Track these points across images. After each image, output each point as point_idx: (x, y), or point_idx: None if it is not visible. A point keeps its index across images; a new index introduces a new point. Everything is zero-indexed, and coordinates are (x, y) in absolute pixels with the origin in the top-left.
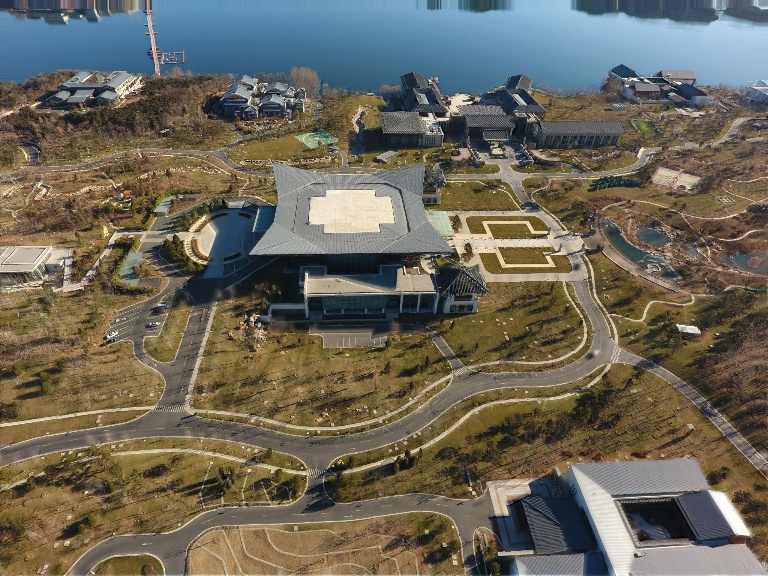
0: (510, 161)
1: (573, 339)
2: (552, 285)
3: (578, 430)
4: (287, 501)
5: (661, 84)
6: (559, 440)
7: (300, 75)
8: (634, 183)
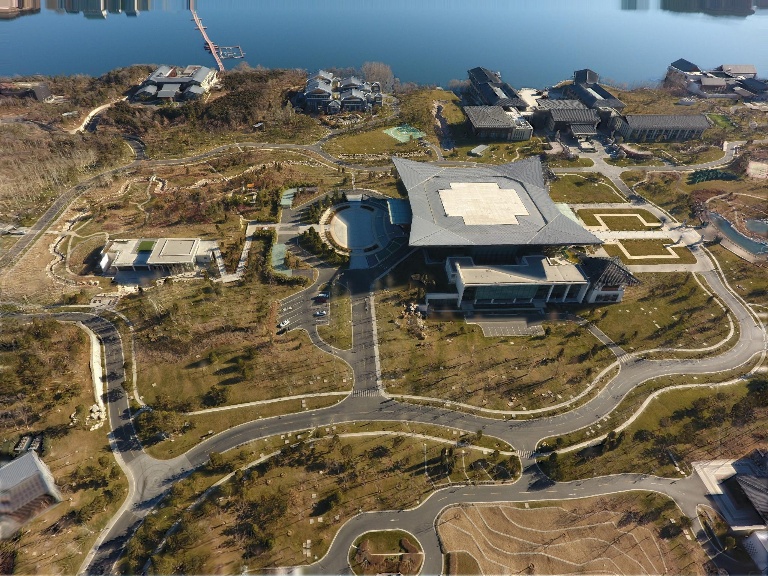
0: (601, 155)
1: (721, 327)
2: (688, 275)
3: (760, 414)
4: (510, 480)
5: (726, 78)
6: (745, 423)
7: (372, 70)
8: (731, 176)
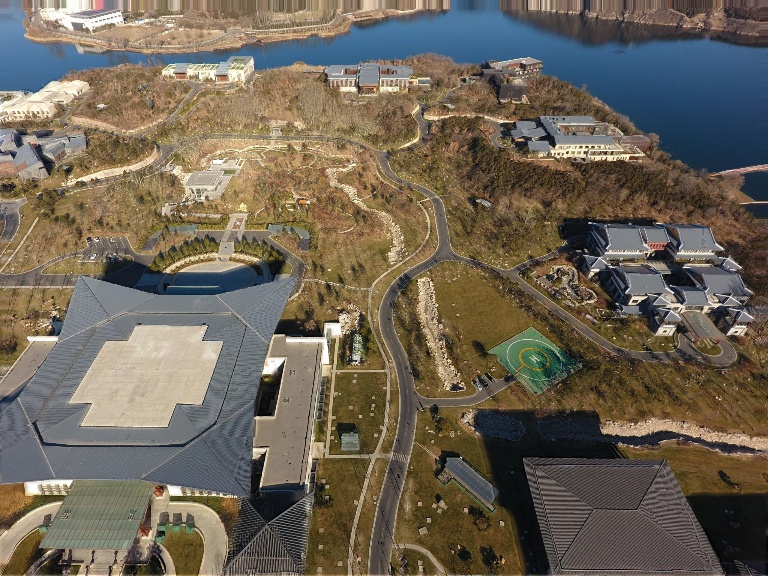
0: None
1: None
2: None
3: None
4: None
5: None
6: None
7: None
8: None
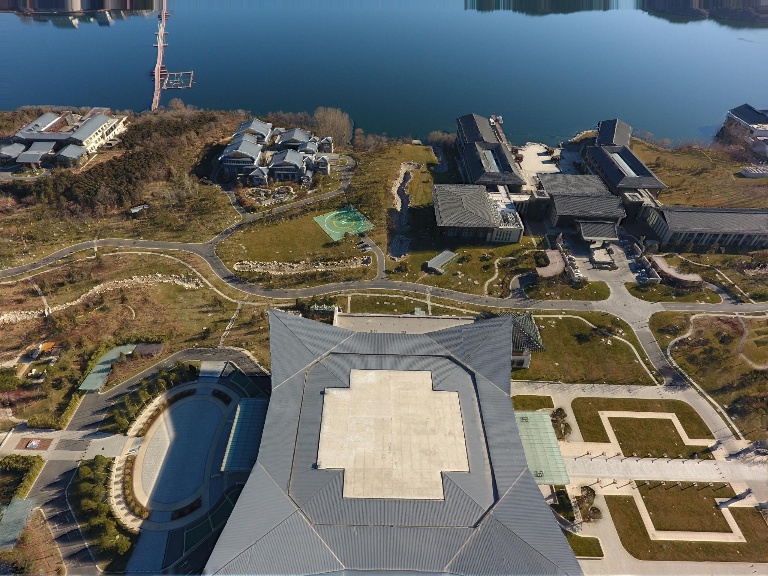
0: (623, 275)
1: None
2: None
3: None
4: None
5: None
6: None
7: (327, 118)
8: None
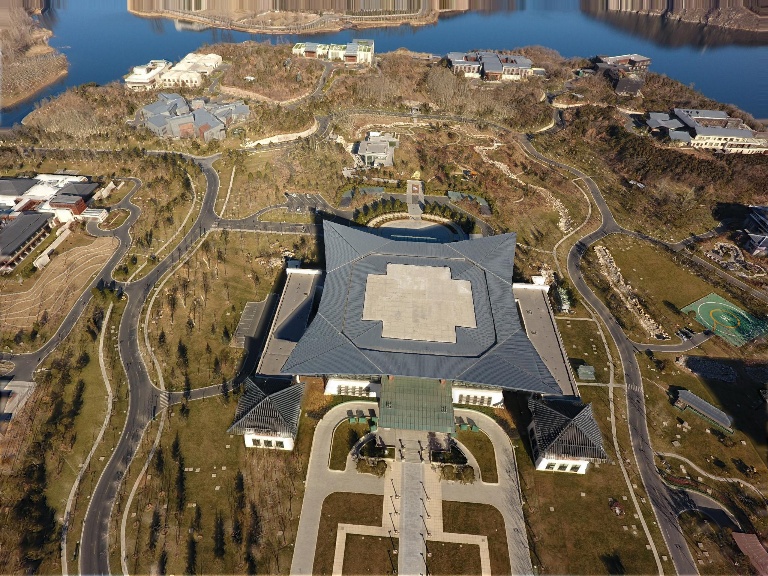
0: None
1: (144, 569)
2: None
3: None
4: None
5: None
6: None
7: None
8: None
